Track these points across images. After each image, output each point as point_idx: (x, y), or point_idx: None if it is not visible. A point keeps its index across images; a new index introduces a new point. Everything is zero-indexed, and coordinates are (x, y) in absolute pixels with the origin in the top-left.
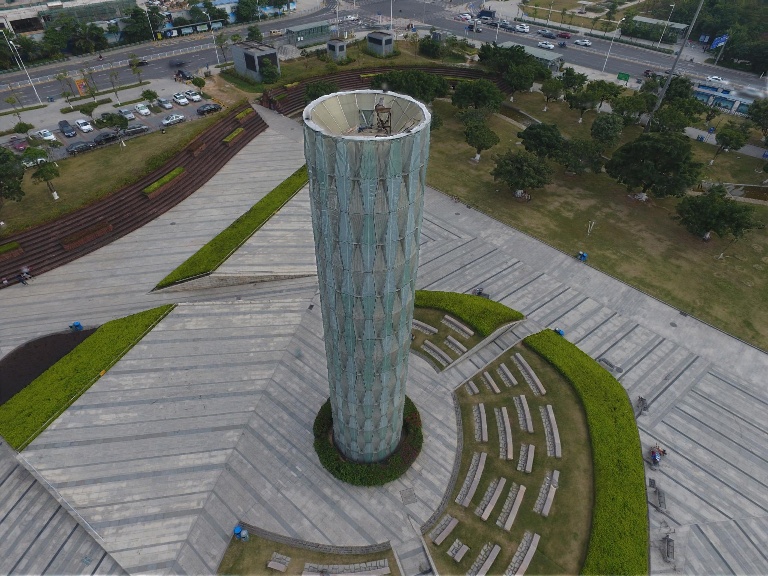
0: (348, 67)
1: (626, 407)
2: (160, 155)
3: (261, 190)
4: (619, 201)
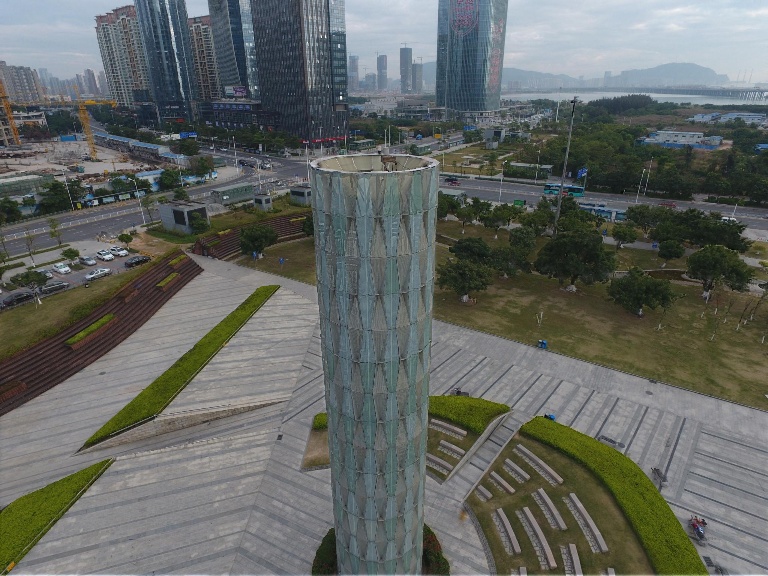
0: (277, 214)
1: (646, 481)
2: (87, 304)
3: (203, 327)
4: (554, 294)
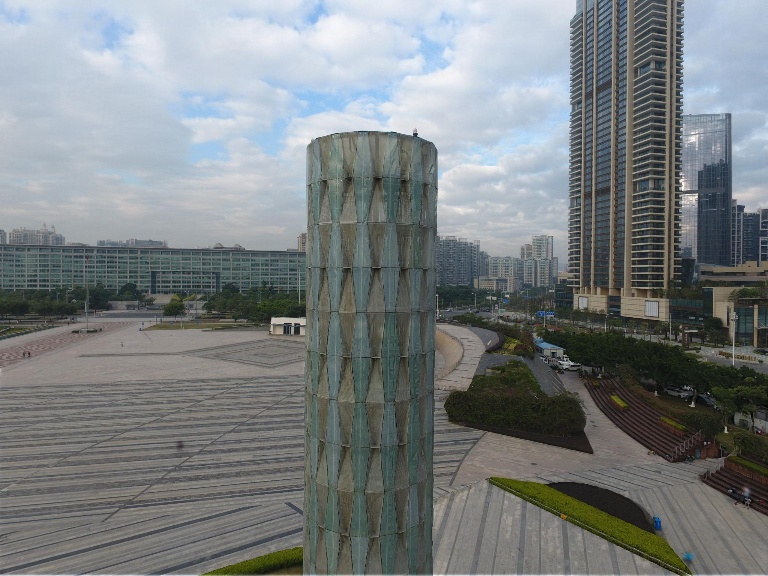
0: None
1: None
2: None
3: None
4: None
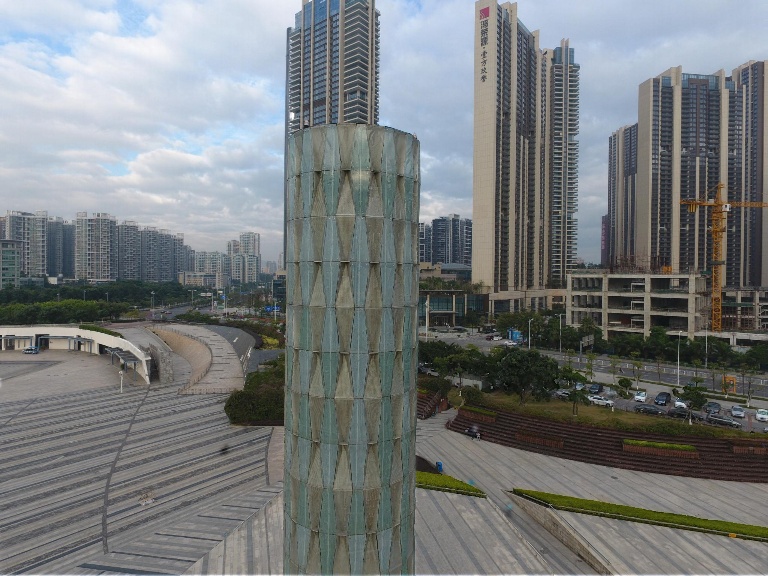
0: None
1: None
2: (680, 425)
3: None
4: None
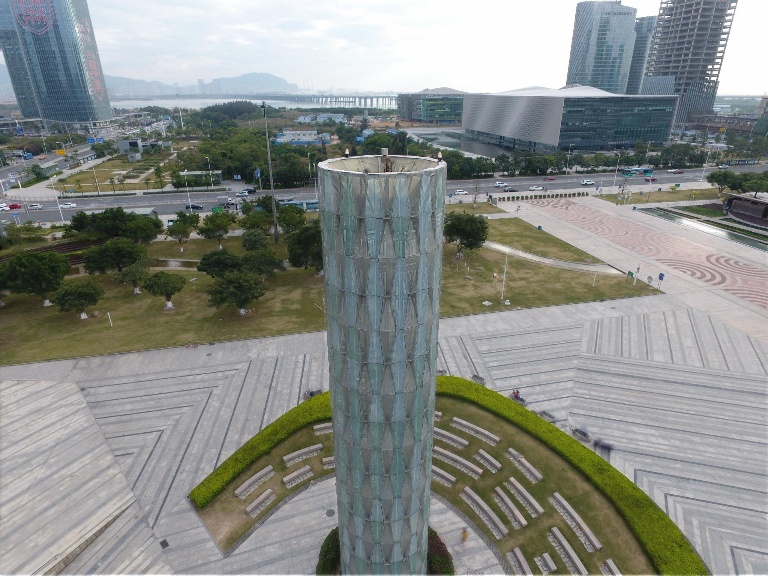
0: None
1: (477, 385)
2: None
3: None
4: (313, 282)
